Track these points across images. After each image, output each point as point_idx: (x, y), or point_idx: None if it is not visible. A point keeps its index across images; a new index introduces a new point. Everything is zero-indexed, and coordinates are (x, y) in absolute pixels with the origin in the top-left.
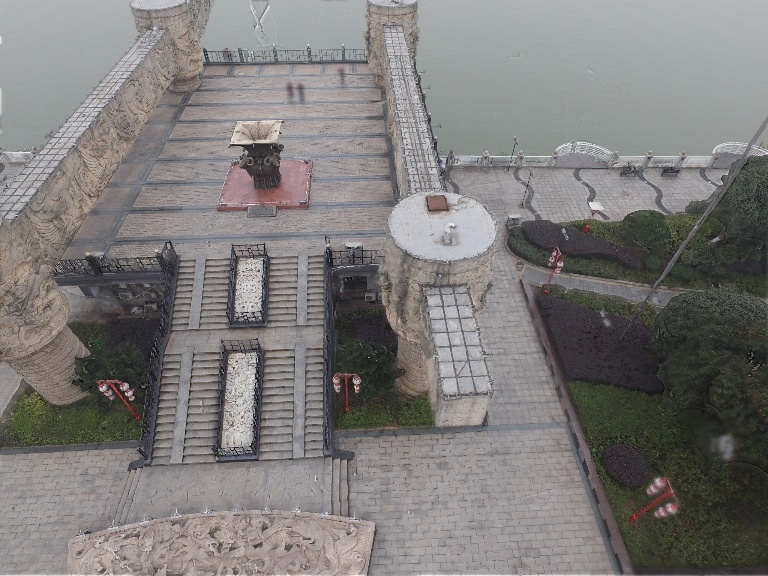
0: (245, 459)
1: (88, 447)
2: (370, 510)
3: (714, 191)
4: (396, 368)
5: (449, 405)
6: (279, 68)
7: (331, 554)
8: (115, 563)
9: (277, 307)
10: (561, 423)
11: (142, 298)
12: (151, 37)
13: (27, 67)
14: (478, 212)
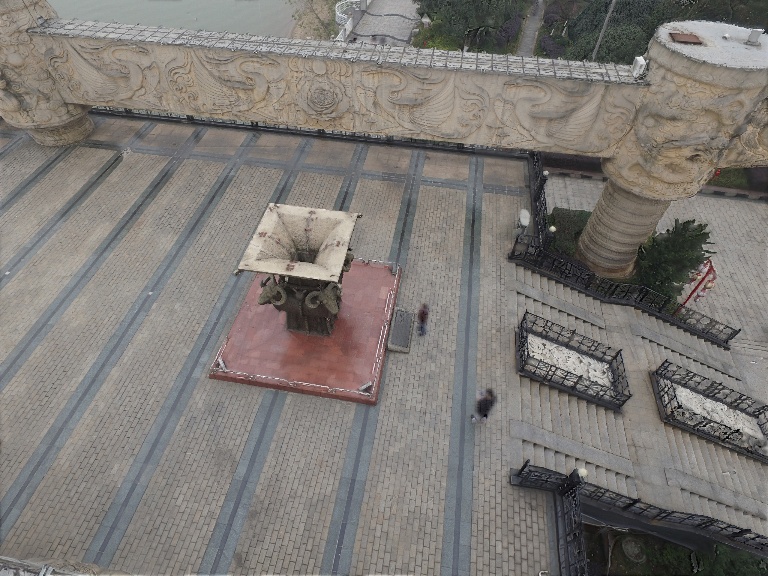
0: None
1: None
2: (759, 327)
3: (445, 15)
4: None
5: None
6: None
7: None
8: None
9: None
10: None
11: None
12: None
13: None
14: (690, 25)
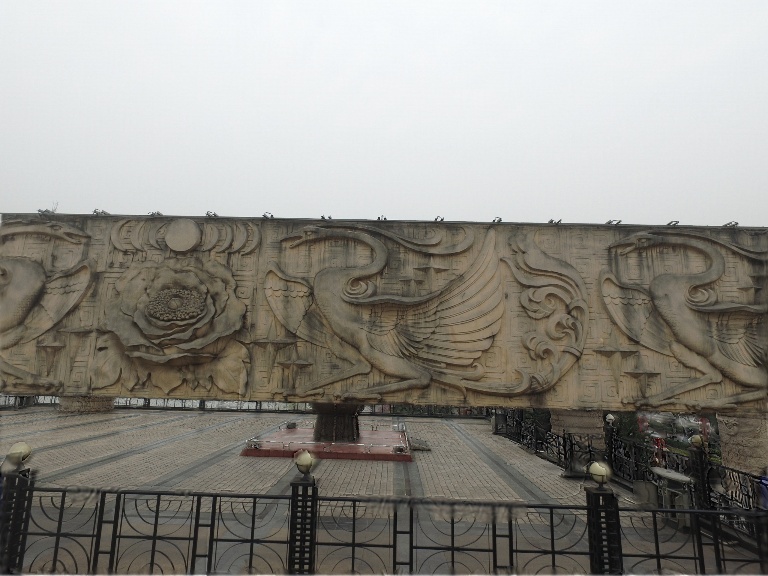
0: None
1: None
2: None
3: None
4: None
5: None
6: None
7: None
8: None
9: None
10: None
11: None
12: None
13: None
14: None
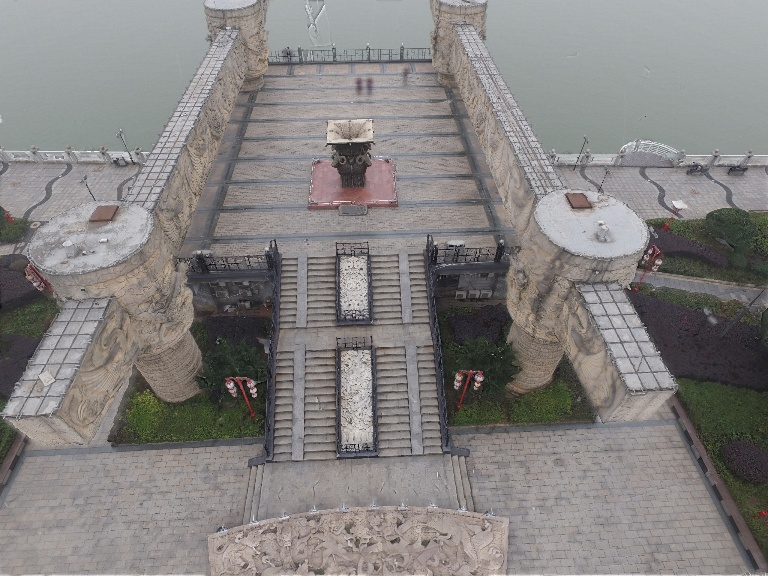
0: (366, 456)
1: (204, 444)
2: (495, 506)
3: None
4: (511, 365)
5: (629, 400)
6: (338, 67)
7: (469, 549)
8: (256, 558)
9: (382, 305)
10: (670, 420)
11: (236, 296)
12: (227, 37)
13: (90, 67)
14: (622, 209)
